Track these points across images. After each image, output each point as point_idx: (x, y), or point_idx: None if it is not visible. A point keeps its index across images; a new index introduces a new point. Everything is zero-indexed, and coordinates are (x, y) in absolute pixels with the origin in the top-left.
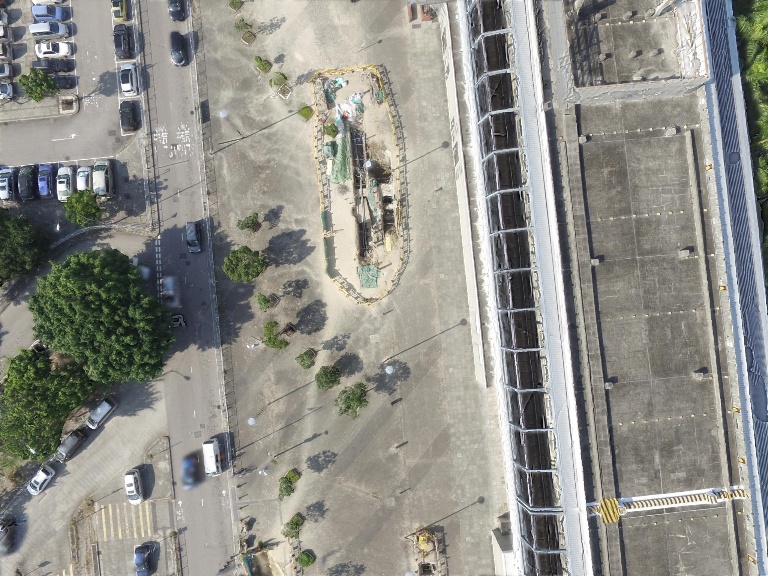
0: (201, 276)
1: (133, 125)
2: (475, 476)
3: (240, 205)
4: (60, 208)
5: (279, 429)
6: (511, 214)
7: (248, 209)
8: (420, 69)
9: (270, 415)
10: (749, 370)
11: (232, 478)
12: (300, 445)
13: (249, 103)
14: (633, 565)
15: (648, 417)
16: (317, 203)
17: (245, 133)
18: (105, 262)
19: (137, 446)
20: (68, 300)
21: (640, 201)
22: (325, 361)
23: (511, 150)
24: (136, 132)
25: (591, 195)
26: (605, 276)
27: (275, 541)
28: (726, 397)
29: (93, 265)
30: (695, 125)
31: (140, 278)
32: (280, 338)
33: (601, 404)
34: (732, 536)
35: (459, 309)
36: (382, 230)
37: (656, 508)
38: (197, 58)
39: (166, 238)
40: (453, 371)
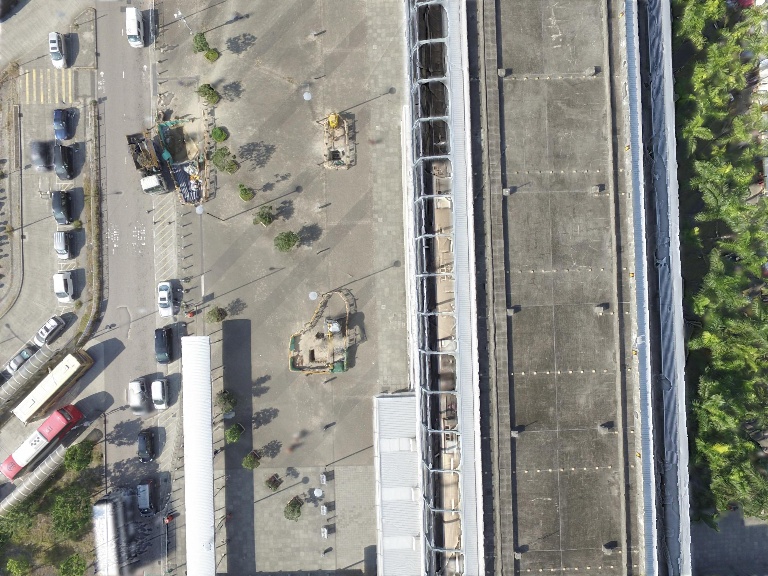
0: None
1: None
2: (389, 67)
3: None
4: None
5: (202, 9)
6: None
7: None
8: None
9: None
10: None
11: (154, 53)
12: (222, 26)
13: None
14: (507, 15)
15: None
16: None
17: None
18: None
19: (64, 16)
20: None
21: None
22: None
23: None
24: None
25: None
26: None
27: (191, 117)
28: None
29: None
30: None
31: None
32: None
33: None
34: None
35: None
36: None
37: None
38: None
39: None
40: None
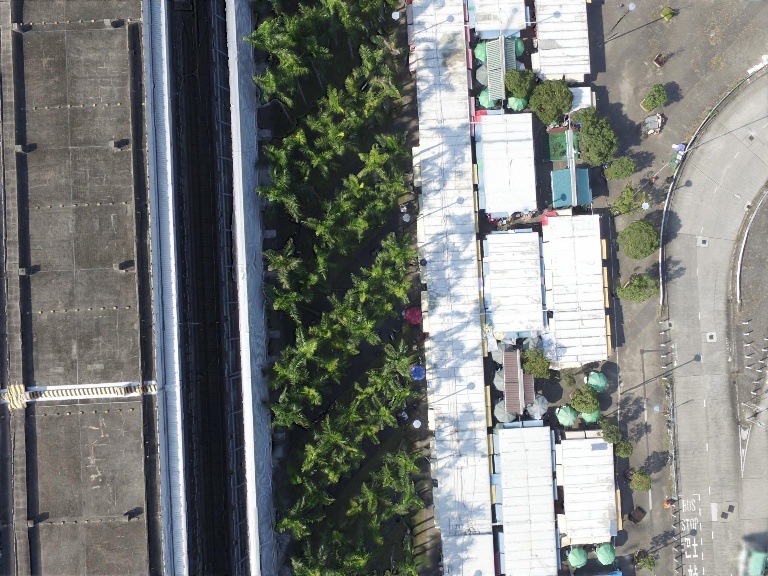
0: None
1: None
2: None
3: None
4: None
5: None
6: None
7: None
8: None
9: None
10: (265, 285)
11: None
12: None
13: None
14: (44, 454)
15: (69, 307)
16: None
17: None
18: None
19: None
20: None
21: (77, 92)
22: None
23: None
24: None
25: (29, 84)
26: (36, 165)
27: None
28: (151, 291)
29: None
30: (139, 19)
31: None
32: None
33: (15, 290)
34: (141, 430)
35: None
36: None
37: (71, 398)
38: None
39: None
40: None
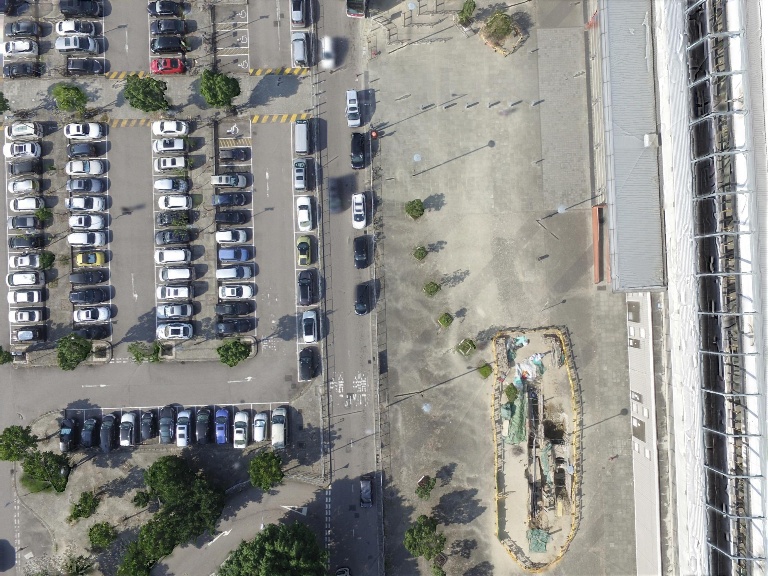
0: (369, 529)
1: (312, 374)
2: None
3: (413, 460)
4: (233, 452)
5: None
6: (712, 529)
7: (421, 464)
8: (603, 333)
9: None
10: None
11: None
12: None
13: (428, 356)
14: None
15: None
16: (490, 463)
17: (422, 387)
18: (298, 548)
19: None
20: None
21: None
22: None
23: None
24: (313, 379)
25: None
26: None
27: None
28: None
29: (287, 553)
30: None
31: None
32: None
33: None
34: None
35: None
36: (554, 494)
37: None
38: (378, 307)
39: (337, 488)
40: None
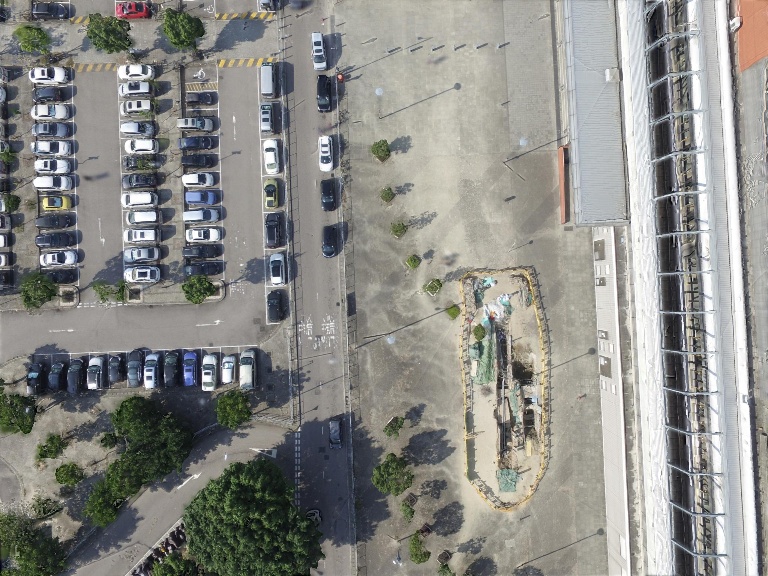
0: (339, 471)
1: (280, 317)
2: None
3: (382, 401)
4: (202, 396)
5: None
6: (675, 457)
7: (390, 406)
8: (570, 273)
9: None
10: None
11: None
12: None
13: (396, 298)
14: None
15: None
16: (459, 403)
17: (391, 328)
18: (263, 482)
19: None
20: (232, 530)
21: None
22: (459, 564)
23: None
24: (281, 322)
25: None
26: None
27: None
28: None
29: (253, 487)
30: None
31: None
32: (423, 550)
33: None
34: None
35: (596, 518)
36: (523, 434)
37: None
38: (346, 249)
39: (306, 431)
40: None
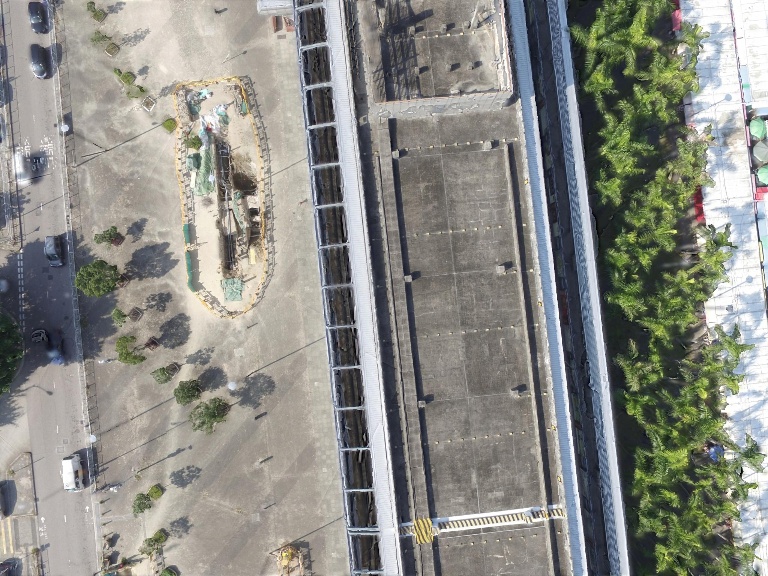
0: (64, 290)
1: None
2: (340, 491)
3: (103, 218)
4: None
5: (142, 444)
6: None
7: (111, 222)
8: (285, 80)
9: (133, 430)
10: None
11: (95, 494)
12: (164, 460)
13: (113, 115)
14: None
15: (465, 435)
16: (181, 216)
17: (108, 146)
18: None
19: None
20: None
21: (457, 216)
22: (189, 375)
23: (328, 165)
24: None
25: (407, 210)
26: (421, 292)
27: (139, 557)
28: (545, 415)
29: None
30: (514, 139)
31: (2, 292)
32: (136, 353)
33: (414, 423)
34: (549, 556)
35: None
36: (247, 243)
37: (473, 528)
38: (60, 70)
39: (28, 252)
40: (318, 385)
